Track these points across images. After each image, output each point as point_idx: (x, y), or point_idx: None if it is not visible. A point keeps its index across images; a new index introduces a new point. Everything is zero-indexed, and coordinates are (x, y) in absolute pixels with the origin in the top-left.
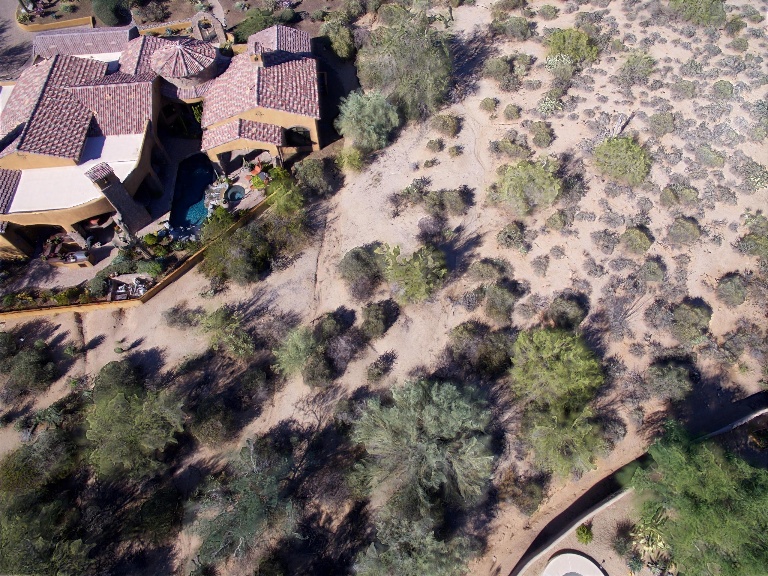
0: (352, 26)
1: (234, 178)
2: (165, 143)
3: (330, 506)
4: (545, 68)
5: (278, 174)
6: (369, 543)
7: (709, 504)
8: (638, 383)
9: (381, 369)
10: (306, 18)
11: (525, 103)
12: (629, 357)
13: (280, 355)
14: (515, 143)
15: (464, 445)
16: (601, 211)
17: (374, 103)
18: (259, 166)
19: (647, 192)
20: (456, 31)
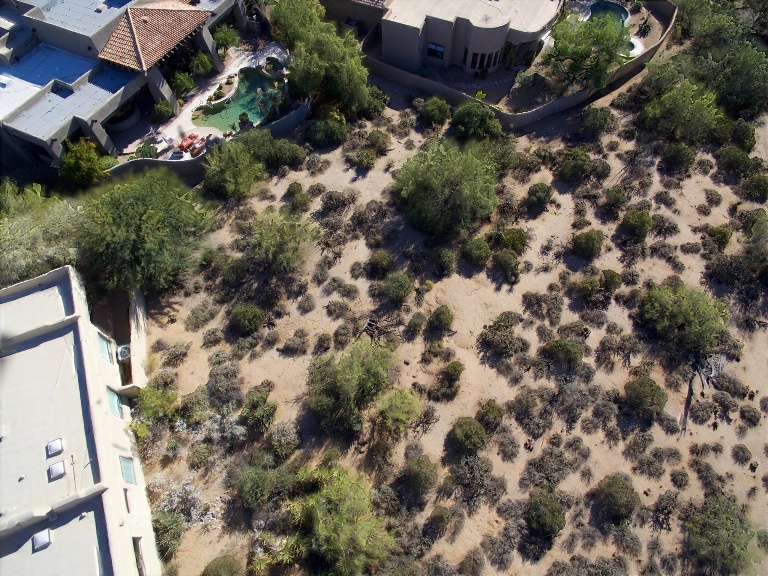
0: None
1: None
2: None
3: None
4: None
5: None
6: None
7: None
8: None
9: None
10: None
11: None
12: None
13: None
14: None
15: None
16: None
17: None
18: None
19: None
20: None
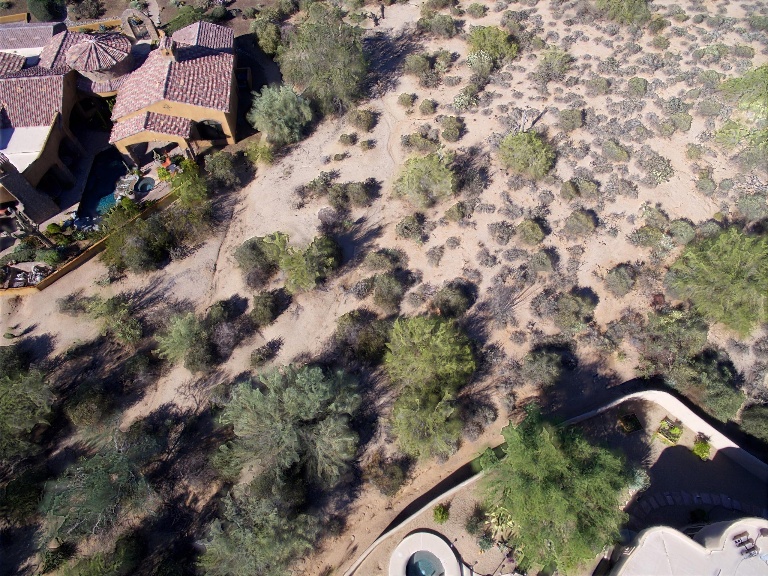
0: (283, 23)
1: (146, 170)
2: (84, 136)
3: (198, 487)
4: (466, 65)
5: (186, 166)
6: (232, 522)
7: (539, 481)
8: (513, 369)
9: (265, 355)
10: (237, 15)
11: (442, 99)
12: (510, 344)
13: (165, 341)
14: (427, 137)
15: (322, 426)
16: (501, 203)
17: (284, 97)
18: (172, 158)
19: (550, 185)
20: (385, 29)
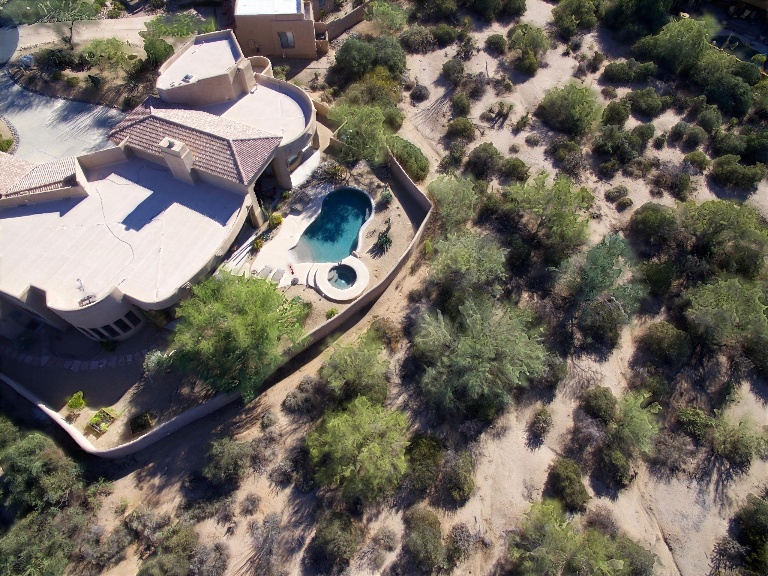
0: None
1: None
2: None
3: None
4: None
5: None
6: None
7: None
8: None
9: None
10: None
11: None
12: (263, 493)
13: None
14: None
15: None
16: None
17: None
18: None
19: None
20: None
